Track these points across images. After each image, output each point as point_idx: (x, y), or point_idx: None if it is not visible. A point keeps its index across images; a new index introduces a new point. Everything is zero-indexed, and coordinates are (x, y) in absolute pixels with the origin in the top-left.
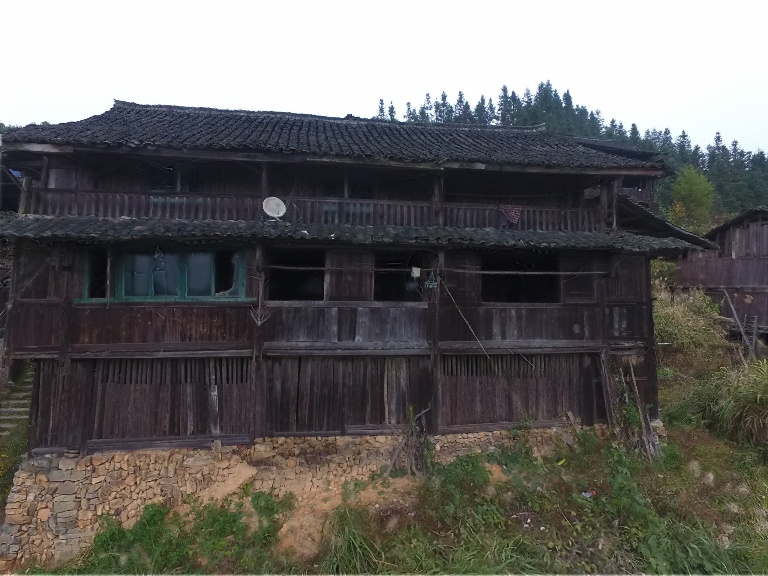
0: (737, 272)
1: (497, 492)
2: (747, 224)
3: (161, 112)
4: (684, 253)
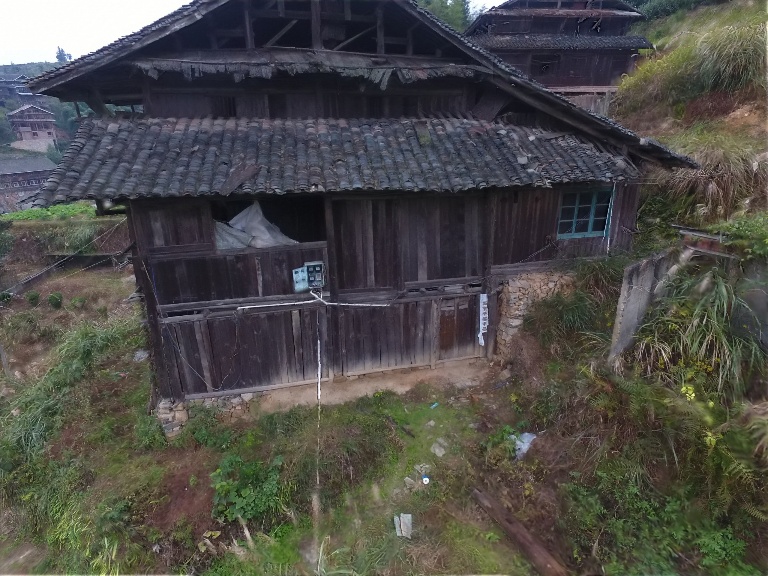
0: None
1: (149, 338)
2: None
3: None
4: None
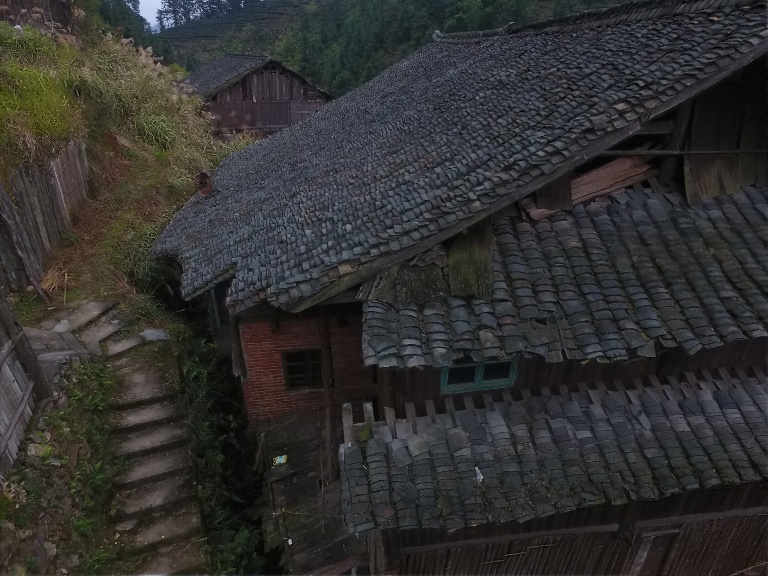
0: (258, 114)
1: None
2: (261, 71)
3: None
4: (215, 95)
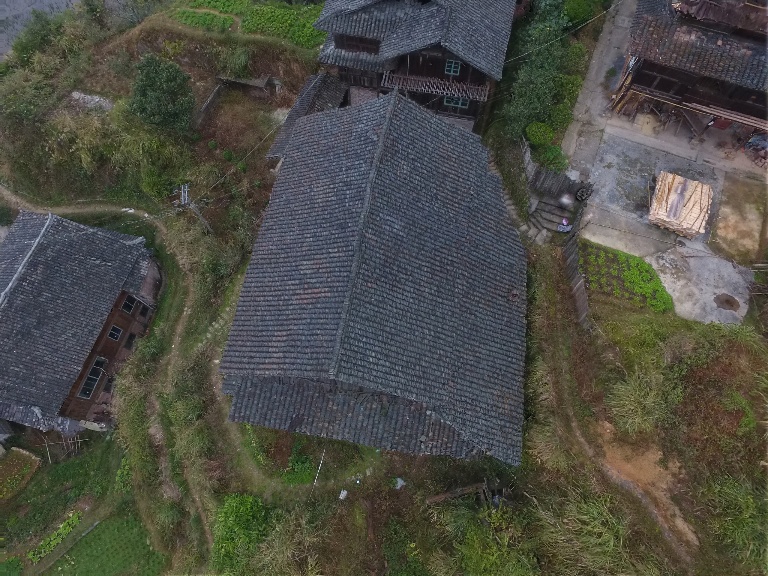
0: None
1: None
2: None
3: (382, 117)
4: None
